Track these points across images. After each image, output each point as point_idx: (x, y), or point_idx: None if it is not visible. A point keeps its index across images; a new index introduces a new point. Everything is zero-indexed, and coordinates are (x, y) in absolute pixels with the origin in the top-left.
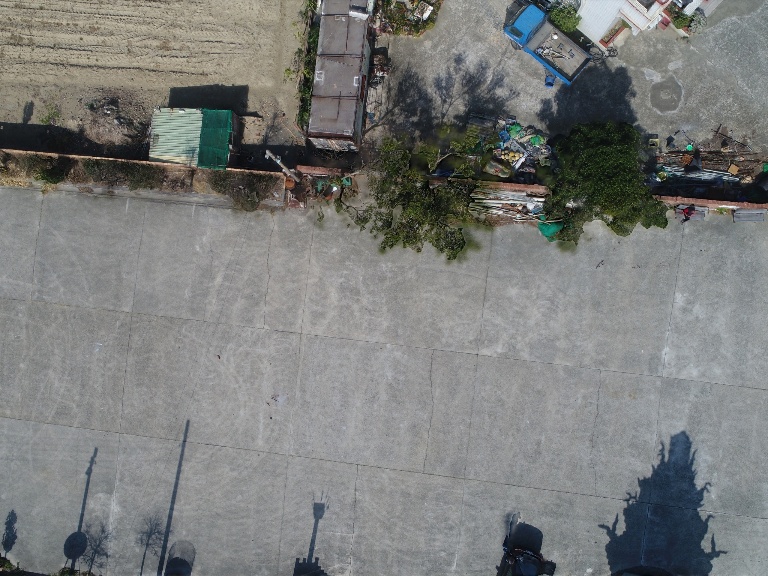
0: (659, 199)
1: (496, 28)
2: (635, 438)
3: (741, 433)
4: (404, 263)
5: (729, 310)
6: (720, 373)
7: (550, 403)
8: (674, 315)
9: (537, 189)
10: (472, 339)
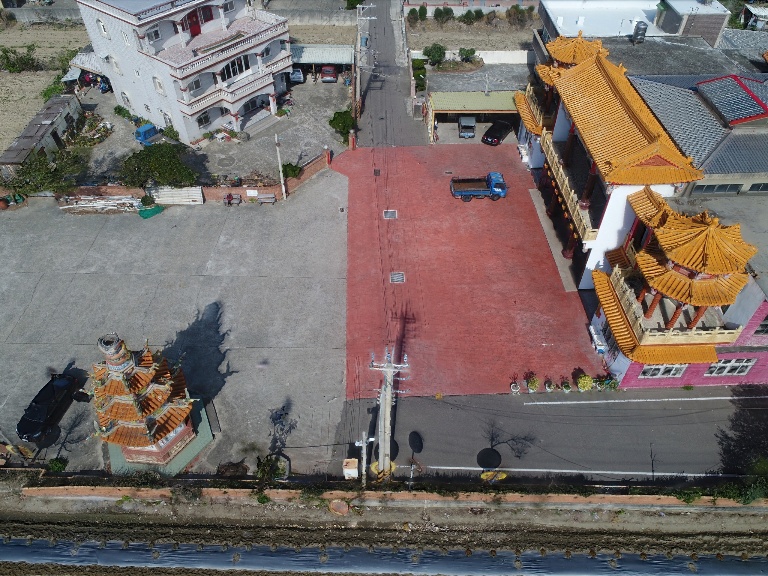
0: (207, 188)
1: (137, 143)
2: (179, 309)
3: (256, 300)
4: (43, 233)
5: (254, 242)
6: (245, 271)
7: (121, 294)
8: (218, 246)
9: (136, 190)
10: (75, 266)
